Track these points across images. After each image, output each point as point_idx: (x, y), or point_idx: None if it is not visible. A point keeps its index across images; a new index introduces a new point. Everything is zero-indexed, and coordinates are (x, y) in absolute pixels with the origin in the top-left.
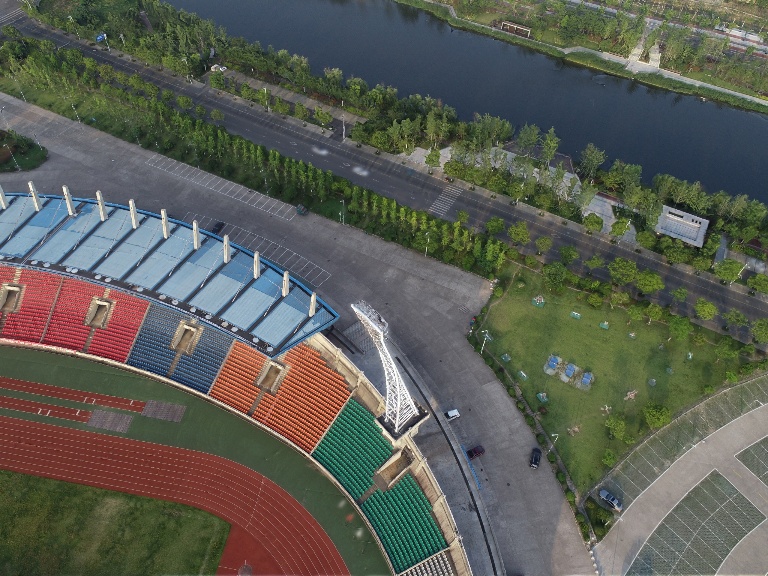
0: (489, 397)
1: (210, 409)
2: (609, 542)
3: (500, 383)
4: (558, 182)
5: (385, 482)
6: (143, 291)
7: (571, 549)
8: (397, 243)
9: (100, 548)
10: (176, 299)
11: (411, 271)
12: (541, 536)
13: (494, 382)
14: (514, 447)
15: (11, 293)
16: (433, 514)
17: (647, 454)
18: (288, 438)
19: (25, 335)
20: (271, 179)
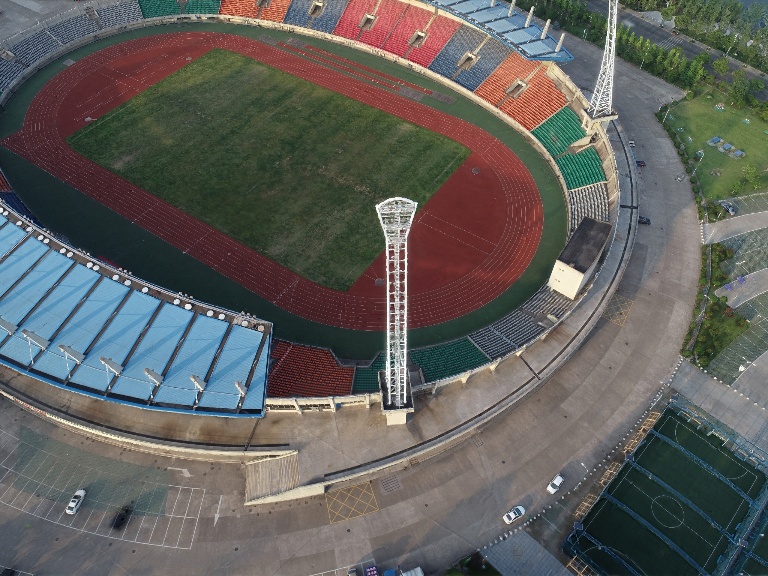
0: (659, 144)
1: (471, 103)
2: (717, 225)
3: (670, 140)
4: (767, 44)
5: (575, 151)
6: (459, 13)
7: (688, 220)
8: (621, 58)
9: (398, 140)
10: (477, 20)
11: (626, 74)
12: (669, 210)
13: (666, 139)
14: (668, 170)
15: (368, 21)
16: (602, 168)
17: (767, 198)
18: (518, 122)
19: (372, 43)
20: (539, 7)
